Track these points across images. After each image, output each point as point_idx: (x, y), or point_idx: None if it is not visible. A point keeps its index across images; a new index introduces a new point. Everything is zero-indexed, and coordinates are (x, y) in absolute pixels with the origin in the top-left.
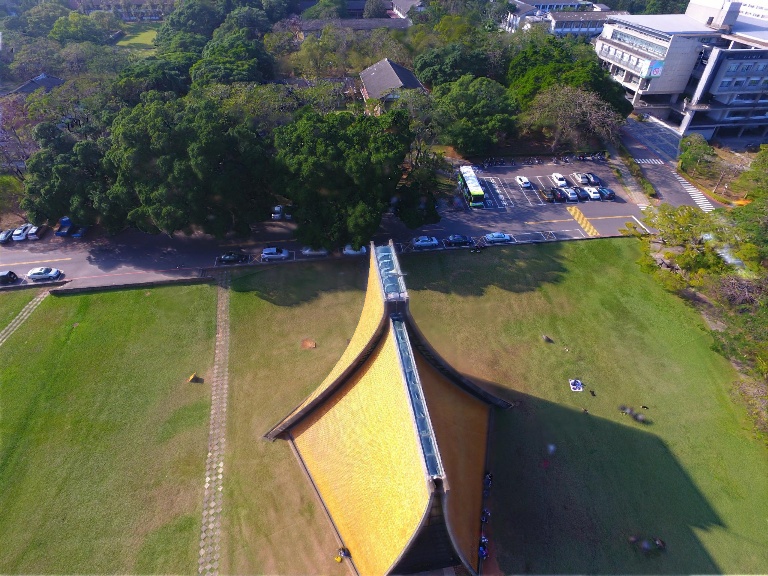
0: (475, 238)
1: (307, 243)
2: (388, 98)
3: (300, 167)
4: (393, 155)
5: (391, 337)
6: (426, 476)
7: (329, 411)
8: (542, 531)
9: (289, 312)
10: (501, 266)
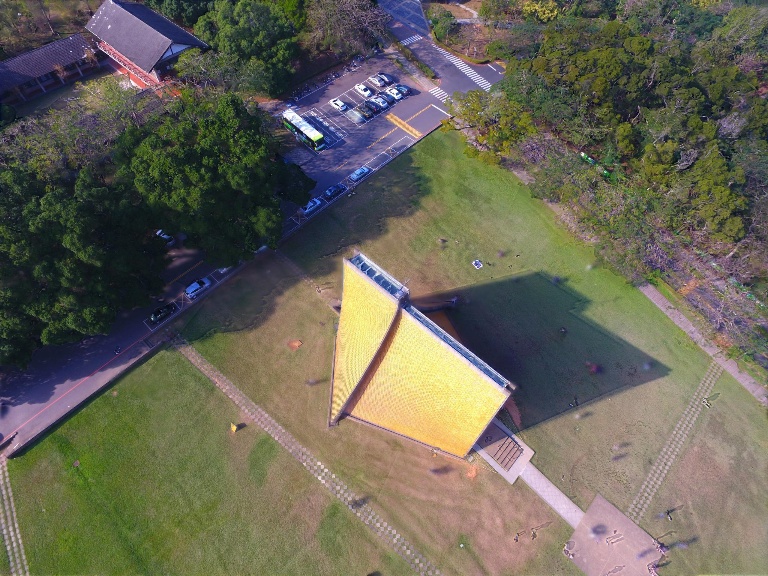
0: (343, 182)
1: (229, 265)
2: (160, 60)
3: (186, 203)
4: (265, 153)
5: (408, 319)
6: (501, 388)
7: (370, 383)
8: (515, 363)
9: (256, 329)
10: (378, 198)
